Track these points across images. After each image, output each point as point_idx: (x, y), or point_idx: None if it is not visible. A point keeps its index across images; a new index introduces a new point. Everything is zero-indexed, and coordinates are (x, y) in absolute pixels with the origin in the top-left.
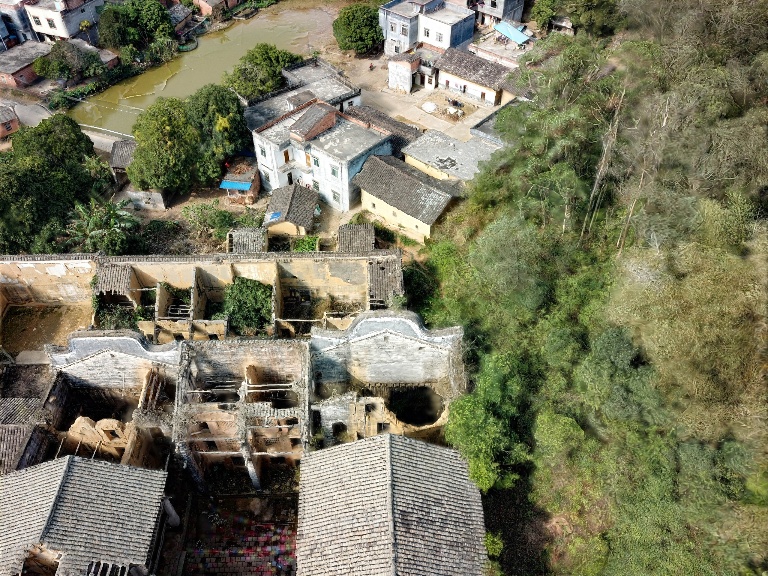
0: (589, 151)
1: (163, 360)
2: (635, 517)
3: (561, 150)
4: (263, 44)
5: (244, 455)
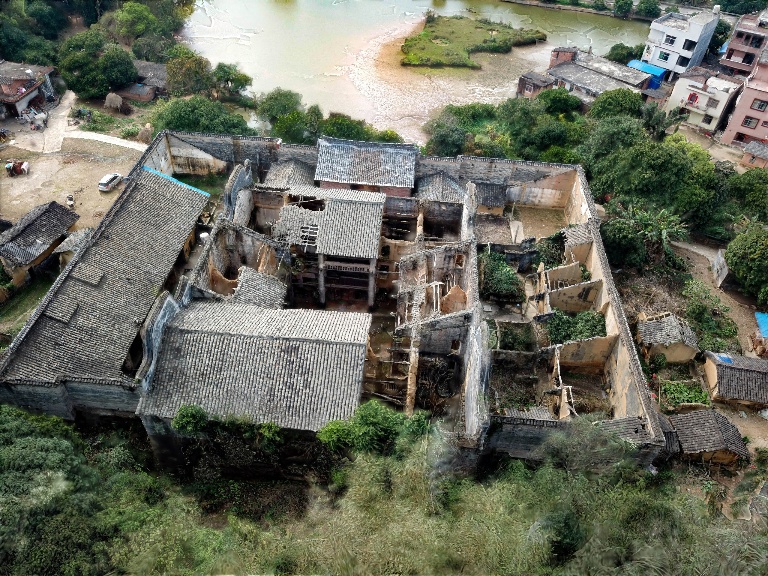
0: None
1: None
2: (264, 568)
3: None
4: None
5: None
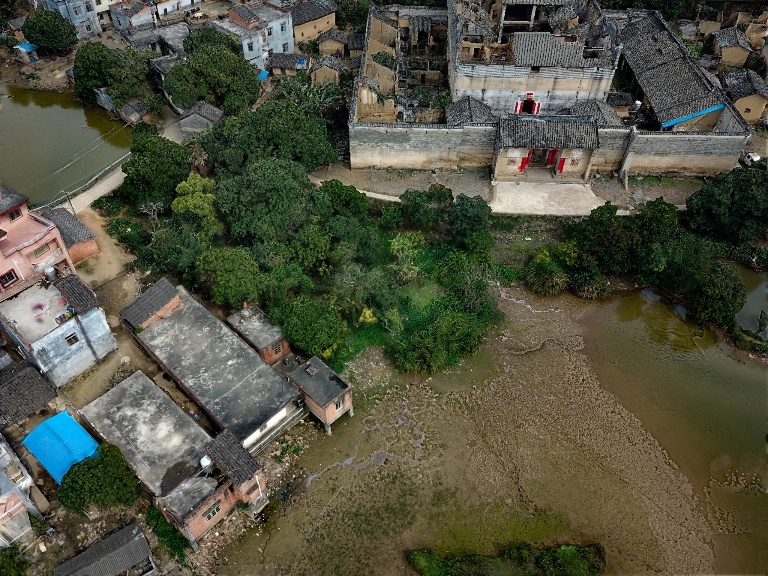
0: None
1: None
2: None
3: None
4: (85, 45)
5: None
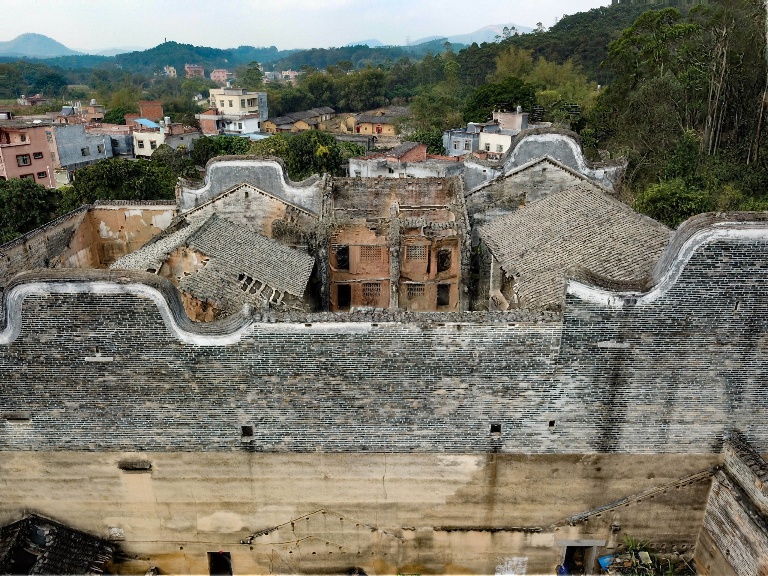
0: (696, 98)
1: (299, 203)
2: None
3: (680, 63)
4: None
5: (392, 280)
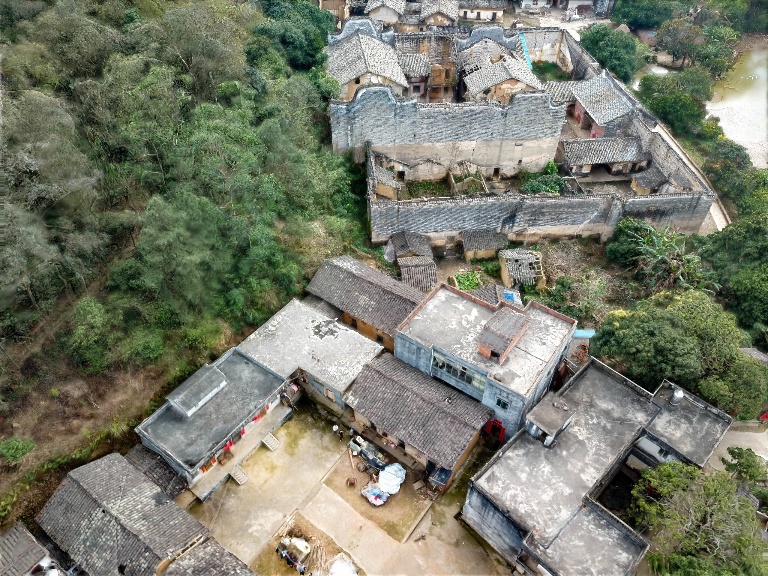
0: None
1: None
2: None
3: None
4: None
5: None
